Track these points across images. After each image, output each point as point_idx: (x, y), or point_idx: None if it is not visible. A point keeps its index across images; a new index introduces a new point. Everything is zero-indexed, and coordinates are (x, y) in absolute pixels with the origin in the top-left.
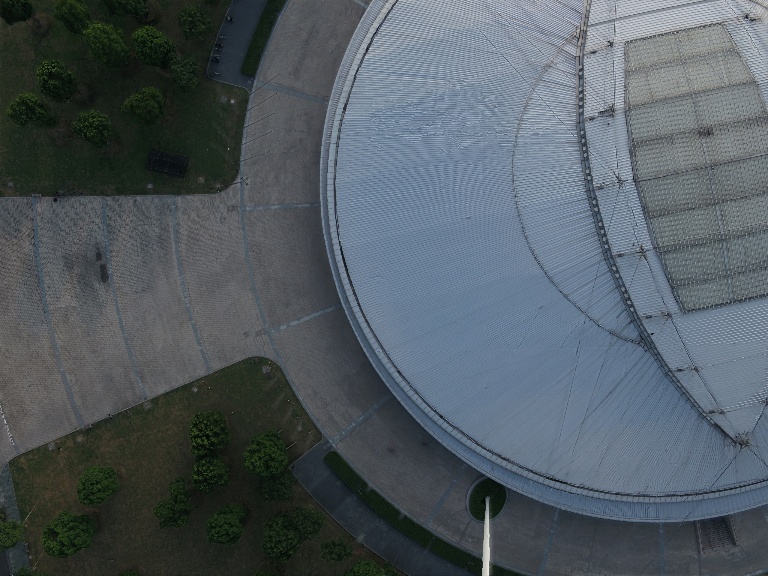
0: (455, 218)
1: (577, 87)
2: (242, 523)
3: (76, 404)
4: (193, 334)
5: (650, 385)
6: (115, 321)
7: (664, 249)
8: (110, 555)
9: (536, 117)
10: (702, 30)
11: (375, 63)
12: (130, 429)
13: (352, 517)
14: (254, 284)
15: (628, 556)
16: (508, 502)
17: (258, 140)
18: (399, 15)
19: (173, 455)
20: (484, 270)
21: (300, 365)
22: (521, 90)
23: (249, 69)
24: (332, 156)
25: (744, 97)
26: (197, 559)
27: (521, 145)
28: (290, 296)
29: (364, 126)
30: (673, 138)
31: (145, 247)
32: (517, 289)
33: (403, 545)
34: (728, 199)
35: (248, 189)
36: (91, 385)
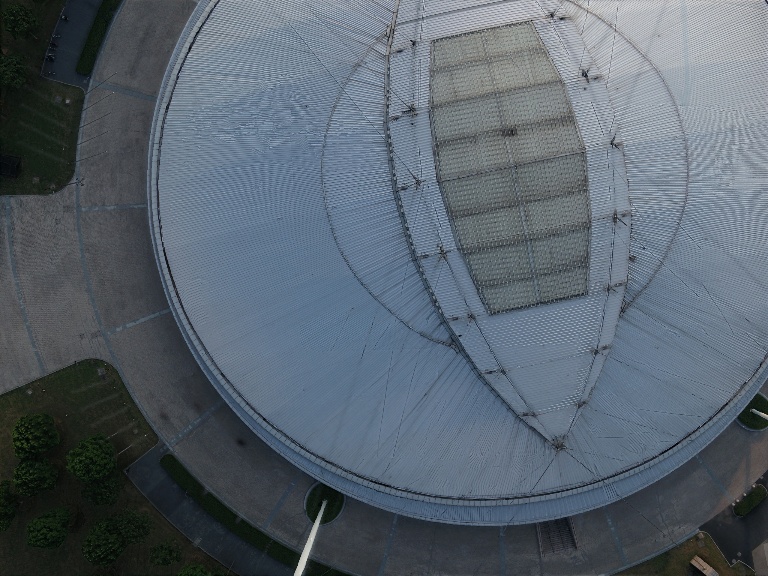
0: (268, 219)
1: (385, 86)
2: (76, 527)
3: None
4: (28, 336)
5: (464, 387)
6: None
7: (468, 250)
8: None
9: (345, 117)
10: (509, 29)
11: (196, 62)
12: None
13: (189, 521)
14: (90, 285)
15: (468, 560)
16: (347, 505)
17: (94, 140)
18: (220, 14)
19: (6, 458)
20: (296, 271)
21: (136, 367)
22: (330, 89)
23: (84, 68)
24: (155, 156)
25: (549, 96)
26: (30, 563)
27: (330, 145)
28: (126, 298)
29: (184, 126)
30: (476, 138)
31: None
32: (328, 291)
33: (240, 549)
34: (532, 200)
35: (84, 190)
36: None
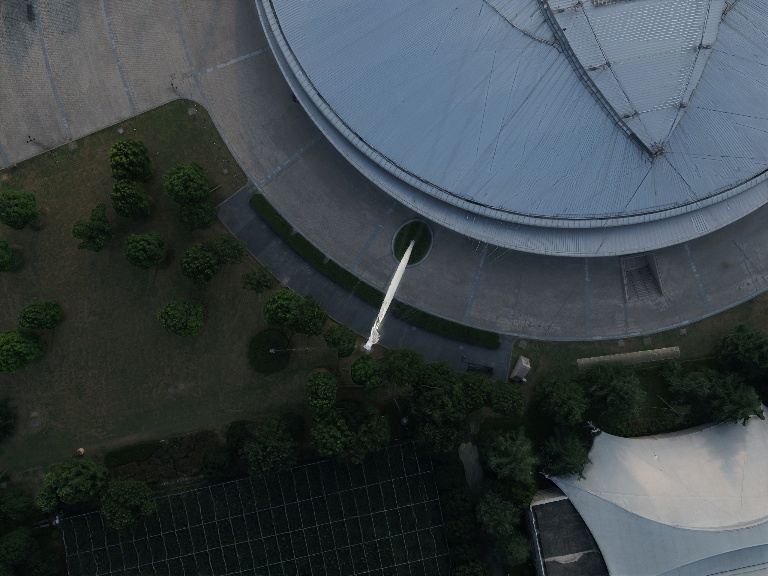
0: None
1: None
2: (166, 263)
3: (1, 143)
4: (119, 75)
5: (565, 90)
6: (41, 61)
7: None
8: (33, 292)
9: None
10: None
11: None
12: (55, 169)
13: (277, 261)
14: (181, 26)
15: (554, 304)
16: (434, 247)
17: None
18: None
19: (98, 194)
20: None
21: (226, 108)
22: None
23: None
24: None
25: None
26: (120, 297)
27: None
28: (217, 39)
29: None
30: None
31: None
32: None
33: (328, 289)
34: None
35: None
36: (16, 124)
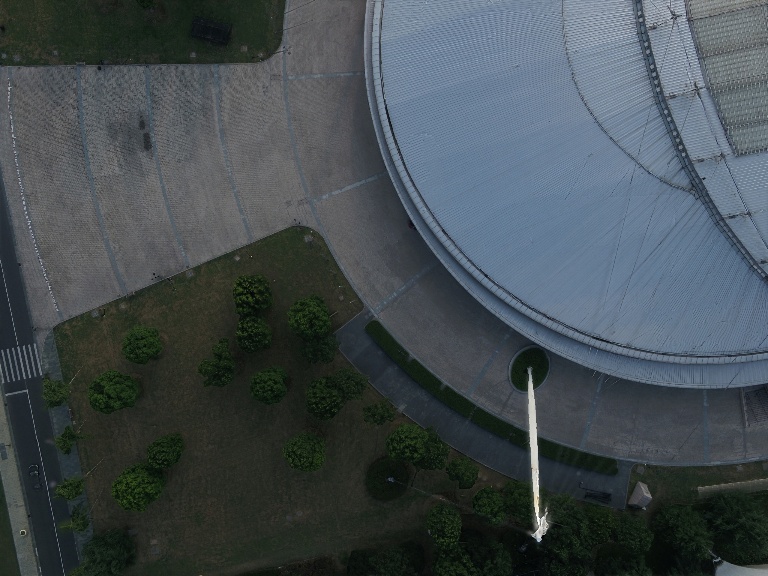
0: (503, 67)
1: None
2: None
3: (119, 272)
4: (235, 203)
5: (700, 235)
6: (158, 189)
7: (718, 89)
8: (153, 421)
9: None
10: None
11: None
12: (173, 297)
13: (393, 387)
14: (296, 153)
15: (672, 429)
16: (550, 373)
17: (301, 9)
18: None
19: (215, 322)
20: (532, 119)
21: (342, 235)
22: None
23: None
24: (377, 14)
25: None
26: (239, 426)
27: None
28: (332, 165)
29: None
30: None
31: (188, 116)
32: (566, 137)
33: (444, 416)
34: None
35: (291, 58)
36: (134, 253)
